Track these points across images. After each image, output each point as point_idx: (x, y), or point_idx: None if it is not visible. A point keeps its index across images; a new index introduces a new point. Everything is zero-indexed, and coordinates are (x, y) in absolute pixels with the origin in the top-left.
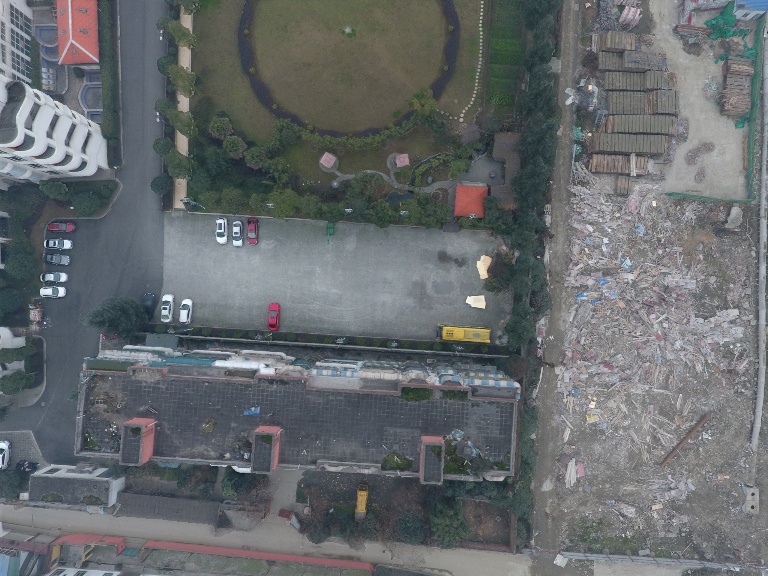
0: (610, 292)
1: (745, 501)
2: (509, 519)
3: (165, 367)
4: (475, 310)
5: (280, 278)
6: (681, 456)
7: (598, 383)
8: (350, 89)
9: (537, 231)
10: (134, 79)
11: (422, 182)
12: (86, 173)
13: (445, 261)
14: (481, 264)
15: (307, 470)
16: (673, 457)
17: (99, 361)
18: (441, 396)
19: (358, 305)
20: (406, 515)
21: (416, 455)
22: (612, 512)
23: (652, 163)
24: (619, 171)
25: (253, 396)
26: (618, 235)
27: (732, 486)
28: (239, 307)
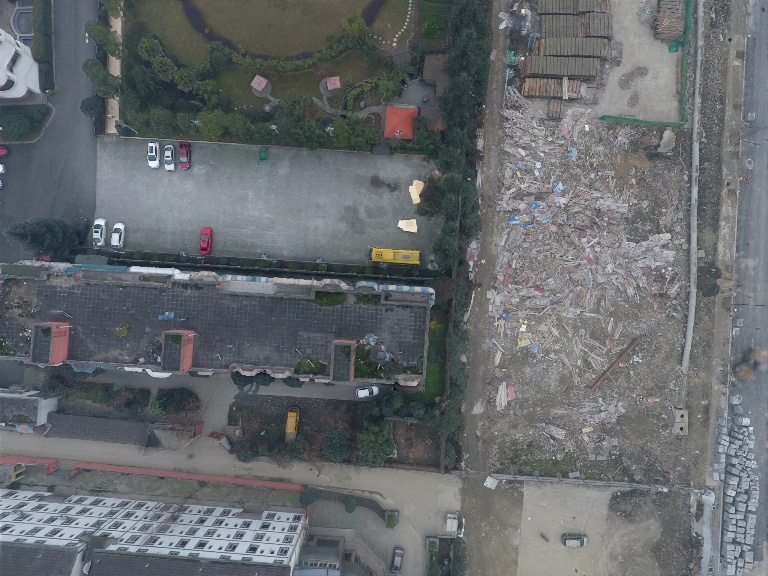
0: (542, 216)
1: (674, 423)
2: (440, 442)
3: (80, 272)
4: (407, 235)
5: (213, 203)
6: (612, 379)
7: (529, 307)
8: (283, 13)
9: (468, 154)
10: (66, 3)
11: (355, 107)
12: (14, 93)
13: (378, 186)
14: (413, 189)
15: (239, 393)
16: (604, 380)
17: (14, 266)
18: (355, 301)
19: (290, 230)
20: (332, 433)
21: (330, 360)
22: (543, 435)
23: (585, 87)
24: (551, 94)
25: (167, 301)
26: (551, 159)
27: (662, 409)
28: (172, 232)
